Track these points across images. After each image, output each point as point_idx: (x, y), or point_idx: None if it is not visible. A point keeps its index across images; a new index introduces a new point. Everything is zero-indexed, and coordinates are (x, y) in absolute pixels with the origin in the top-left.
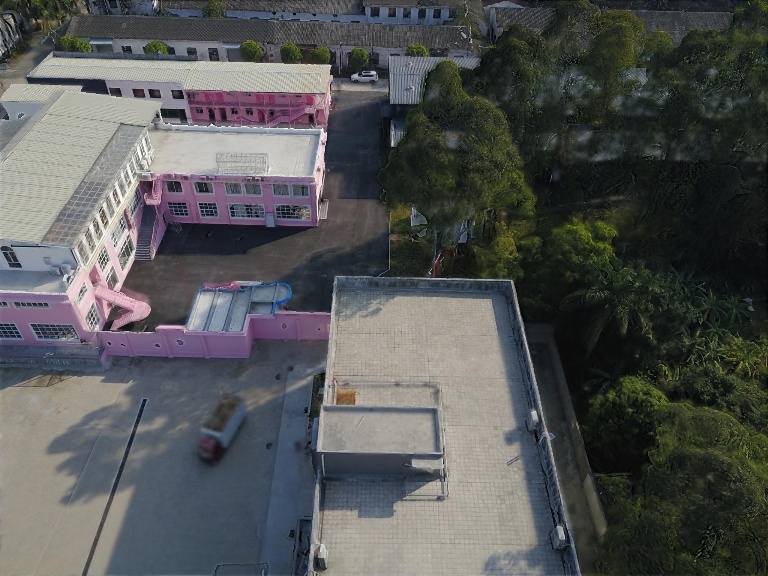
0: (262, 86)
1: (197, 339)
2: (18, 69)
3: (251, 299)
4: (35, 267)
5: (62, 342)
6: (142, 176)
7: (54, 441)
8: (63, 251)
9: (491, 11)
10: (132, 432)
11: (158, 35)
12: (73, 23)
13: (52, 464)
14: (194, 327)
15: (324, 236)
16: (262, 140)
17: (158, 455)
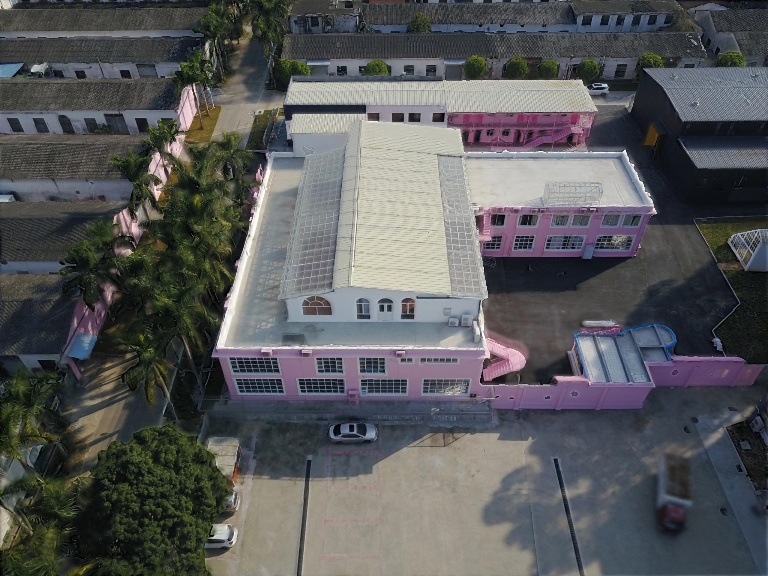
0: (528, 106)
1: (598, 391)
2: (234, 94)
3: (637, 344)
4: (427, 318)
5: (448, 396)
6: None
7: (486, 510)
8: (471, 302)
9: (697, 14)
10: (563, 497)
11: (376, 54)
12: (286, 44)
13: (499, 537)
14: (595, 378)
15: (648, 267)
16: (564, 166)
17: (606, 524)
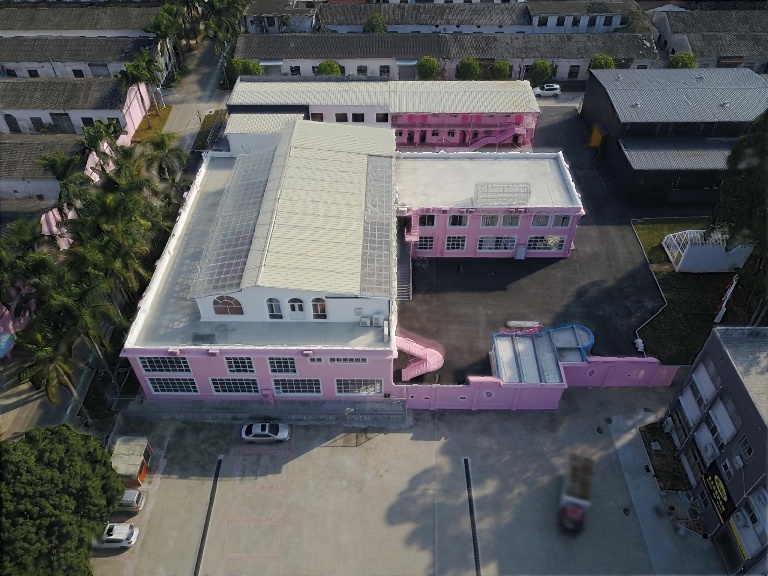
0: (471, 106)
1: (511, 391)
2: (186, 94)
3: (554, 345)
4: (339, 318)
5: (362, 396)
6: (399, 211)
7: (391, 510)
8: (380, 302)
9: (655, 16)
10: (468, 497)
11: (329, 54)
12: (239, 44)
13: (400, 537)
14: (508, 378)
15: (580, 268)
16: (499, 166)
17: (508, 524)
